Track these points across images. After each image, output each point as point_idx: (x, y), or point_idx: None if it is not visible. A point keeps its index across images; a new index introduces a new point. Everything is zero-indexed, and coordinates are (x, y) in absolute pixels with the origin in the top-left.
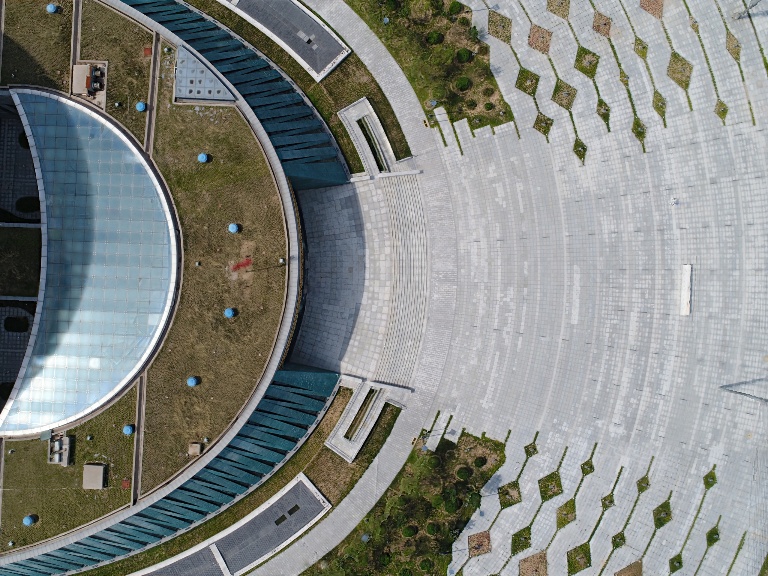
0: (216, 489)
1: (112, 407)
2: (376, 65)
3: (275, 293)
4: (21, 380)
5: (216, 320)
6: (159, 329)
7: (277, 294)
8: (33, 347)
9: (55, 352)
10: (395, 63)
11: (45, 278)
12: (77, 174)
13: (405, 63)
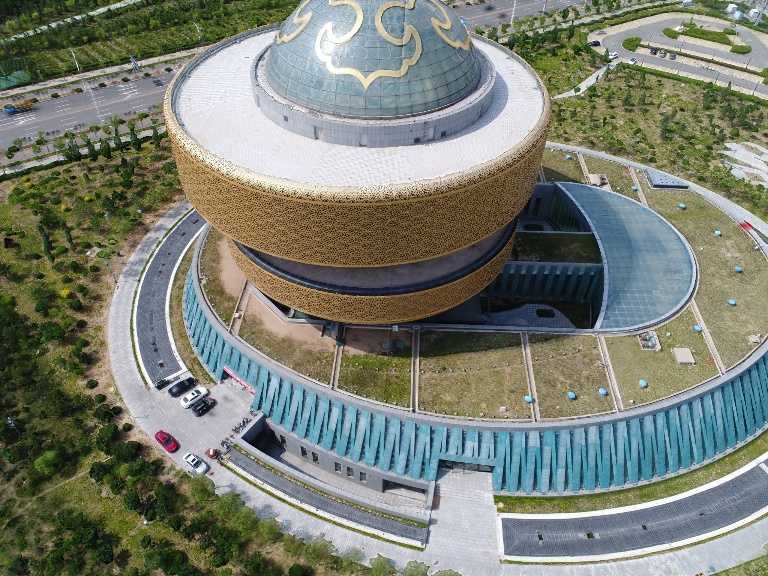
0: (760, 398)
1: (677, 318)
2: (728, 207)
3: (761, 262)
4: (606, 302)
5: (729, 274)
6: (694, 276)
7: (763, 263)
8: (608, 285)
9: (625, 287)
10: (739, 206)
11: (604, 253)
12: (607, 212)
13: (745, 206)
